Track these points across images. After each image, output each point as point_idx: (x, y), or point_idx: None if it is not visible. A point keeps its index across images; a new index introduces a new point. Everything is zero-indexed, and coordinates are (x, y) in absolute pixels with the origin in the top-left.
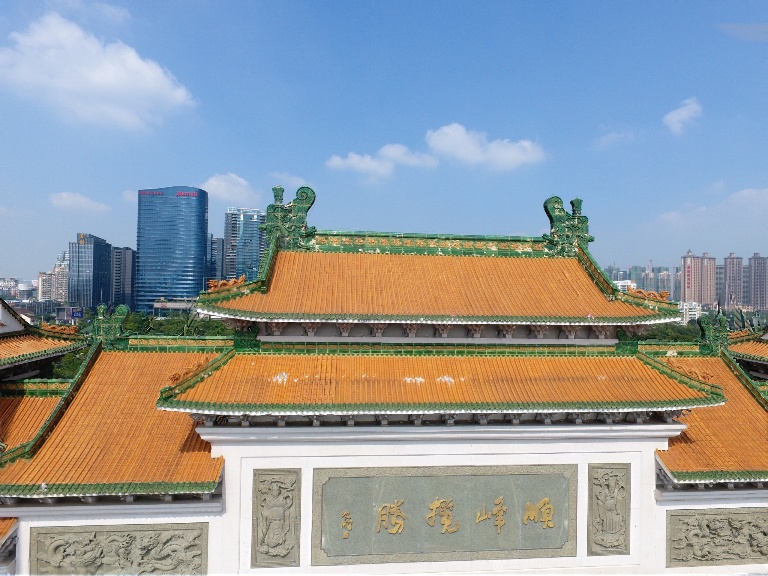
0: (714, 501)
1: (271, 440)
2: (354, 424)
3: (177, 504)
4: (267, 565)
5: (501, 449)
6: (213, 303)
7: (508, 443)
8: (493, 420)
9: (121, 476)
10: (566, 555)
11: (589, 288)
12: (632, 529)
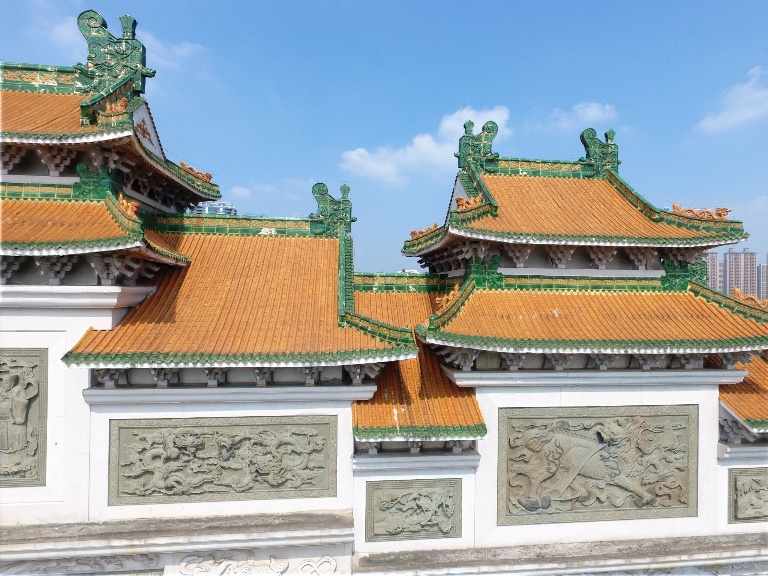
0: (190, 407)
1: None
2: None
3: None
4: None
5: None
6: None
7: None
8: None
9: None
10: None
11: None
12: (50, 448)
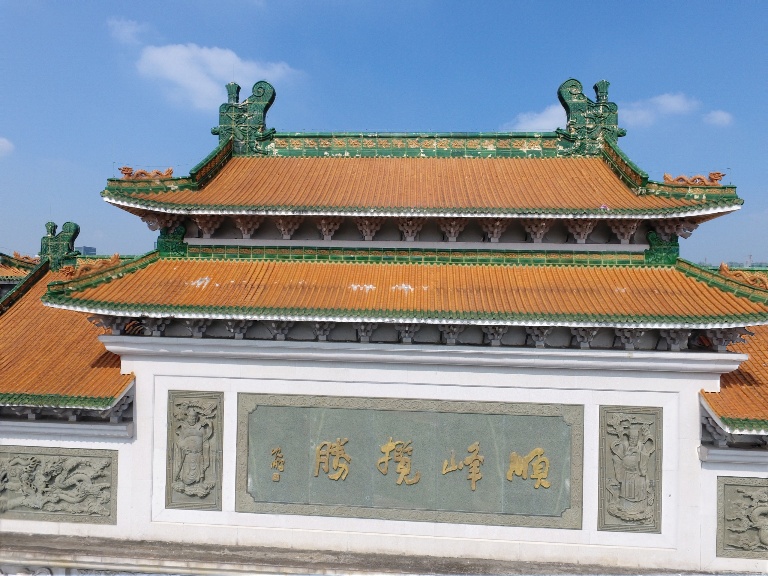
0: None
1: (186, 355)
2: (285, 339)
3: (79, 424)
4: (184, 506)
5: (476, 380)
6: (125, 193)
7: (486, 372)
8: (468, 343)
9: (16, 387)
10: (567, 526)
11: (612, 184)
12: (665, 499)
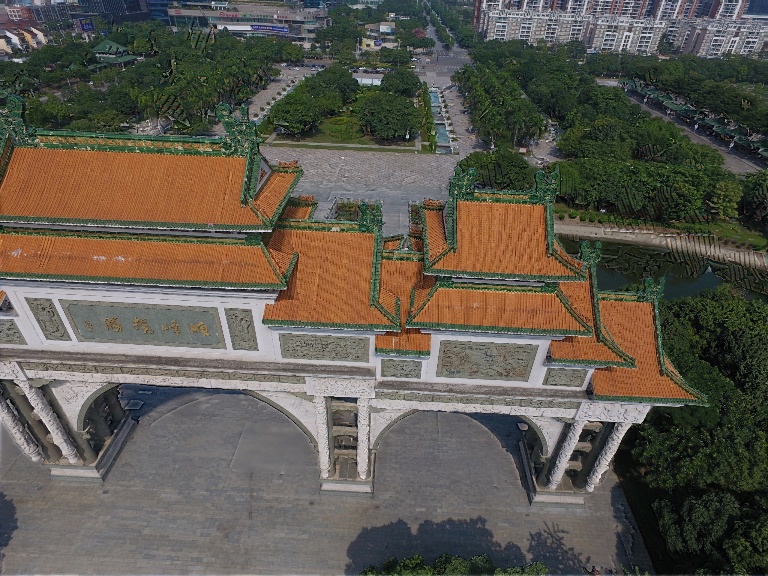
0: (309, 331)
1: (24, 285)
2: None
3: None
4: (54, 339)
5: (166, 297)
6: None
7: (169, 295)
8: None
9: None
10: (220, 348)
11: (237, 192)
12: (258, 340)
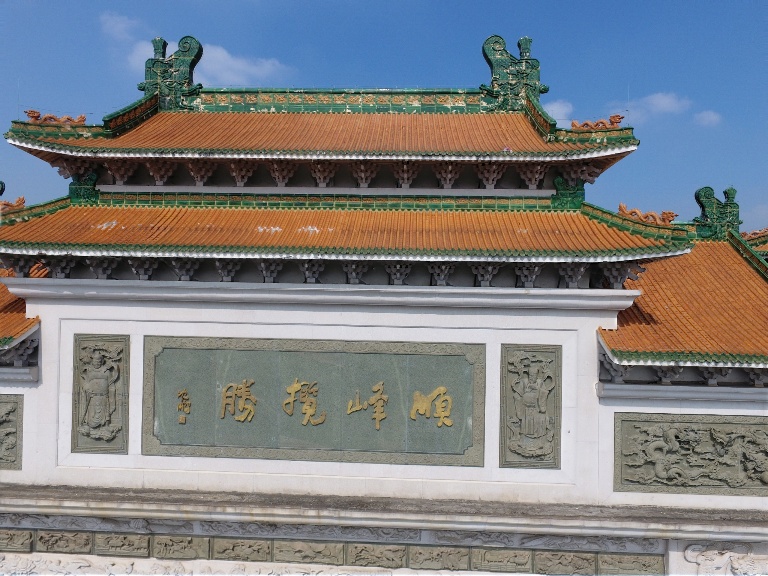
0: (687, 403)
1: (91, 297)
2: (189, 280)
3: None
4: (90, 450)
5: (380, 320)
6: (31, 136)
7: (390, 312)
8: None
9: None
10: (469, 464)
11: (526, 135)
12: (564, 435)
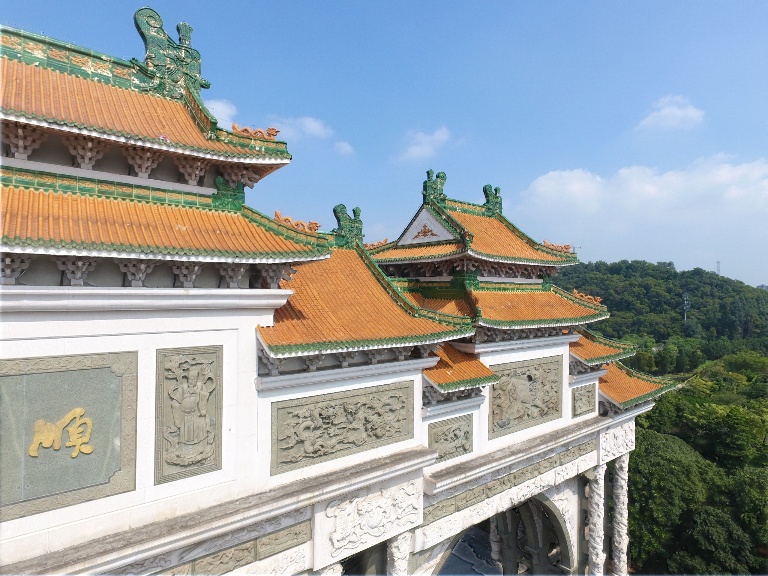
0: (328, 385)
1: None
2: None
3: None
4: None
5: None
6: None
7: None
8: None
9: None
10: (117, 492)
11: (186, 127)
12: (225, 434)
